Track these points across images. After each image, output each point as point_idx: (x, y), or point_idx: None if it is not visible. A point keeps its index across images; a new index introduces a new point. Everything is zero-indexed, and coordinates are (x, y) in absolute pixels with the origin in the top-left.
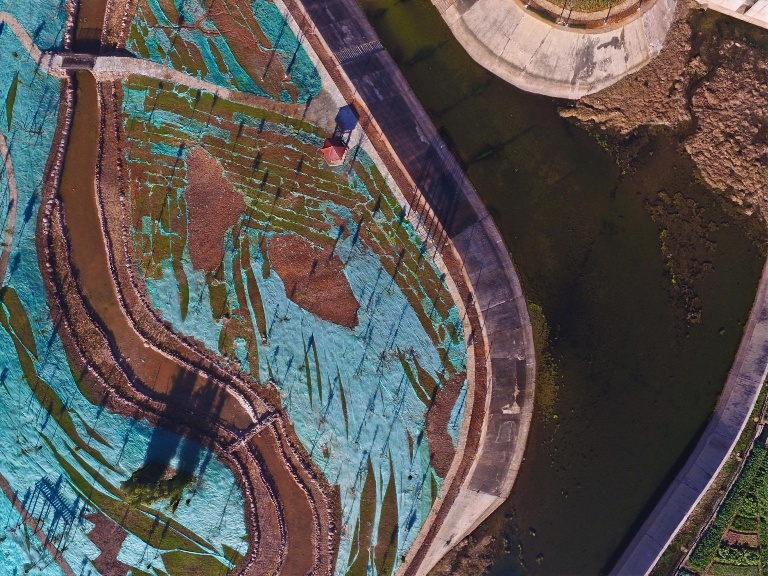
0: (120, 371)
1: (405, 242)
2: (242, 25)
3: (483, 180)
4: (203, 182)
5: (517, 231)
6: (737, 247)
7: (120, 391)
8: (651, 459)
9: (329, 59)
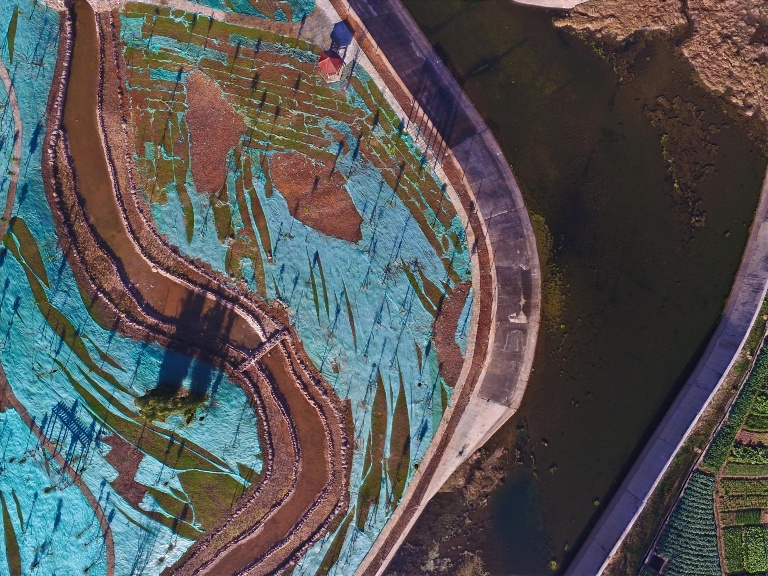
0: (130, 296)
1: (405, 154)
2: None
3: (480, 94)
4: (203, 105)
5: (517, 143)
6: (739, 148)
7: (130, 316)
8: (661, 365)
9: None
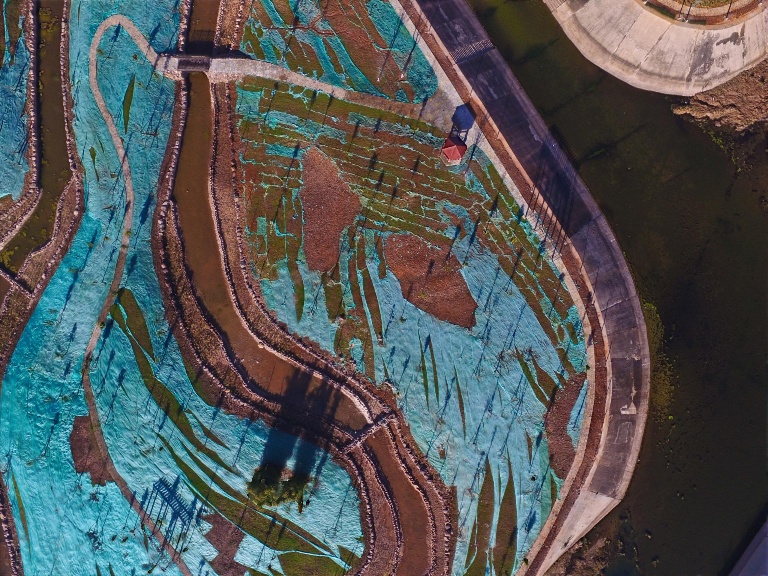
0: (235, 372)
1: (523, 241)
2: (357, 25)
3: (595, 179)
4: (318, 183)
5: (630, 230)
6: None
7: (235, 392)
8: None
9: (445, 58)
